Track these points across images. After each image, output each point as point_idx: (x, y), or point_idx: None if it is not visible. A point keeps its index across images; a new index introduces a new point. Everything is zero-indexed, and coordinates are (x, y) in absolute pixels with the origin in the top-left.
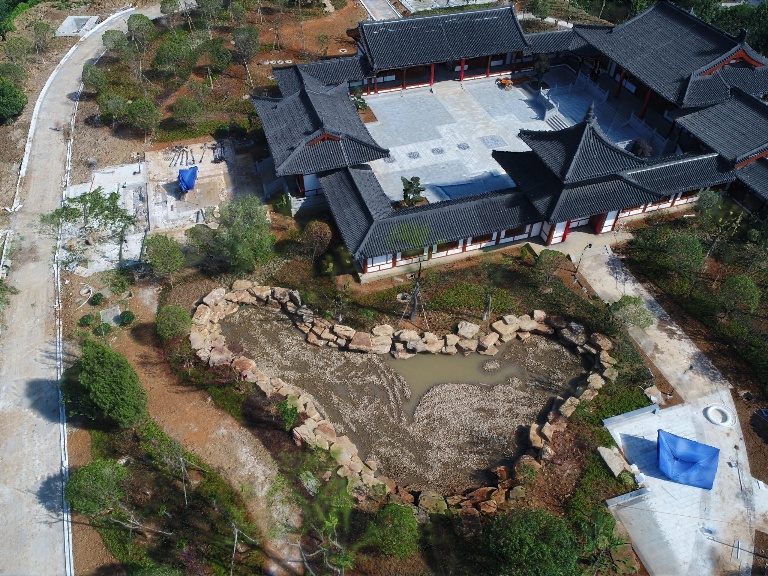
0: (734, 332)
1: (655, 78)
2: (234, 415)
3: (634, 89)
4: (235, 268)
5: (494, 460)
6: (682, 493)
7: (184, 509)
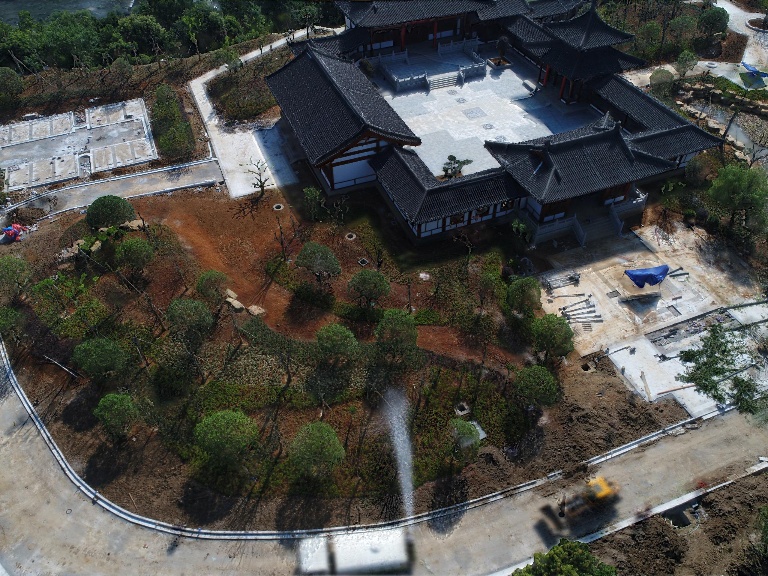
0: (653, 51)
1: (452, 8)
2: None
3: (392, 43)
4: (734, 233)
5: None
6: (766, 78)
7: None
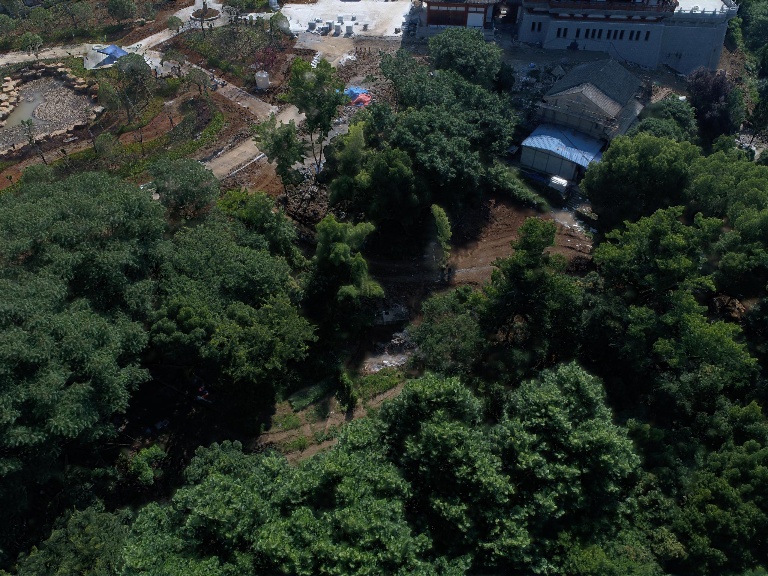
0: (58, 34)
1: None
2: (11, 164)
3: None
4: None
5: (87, 101)
6: None
7: (65, 169)
